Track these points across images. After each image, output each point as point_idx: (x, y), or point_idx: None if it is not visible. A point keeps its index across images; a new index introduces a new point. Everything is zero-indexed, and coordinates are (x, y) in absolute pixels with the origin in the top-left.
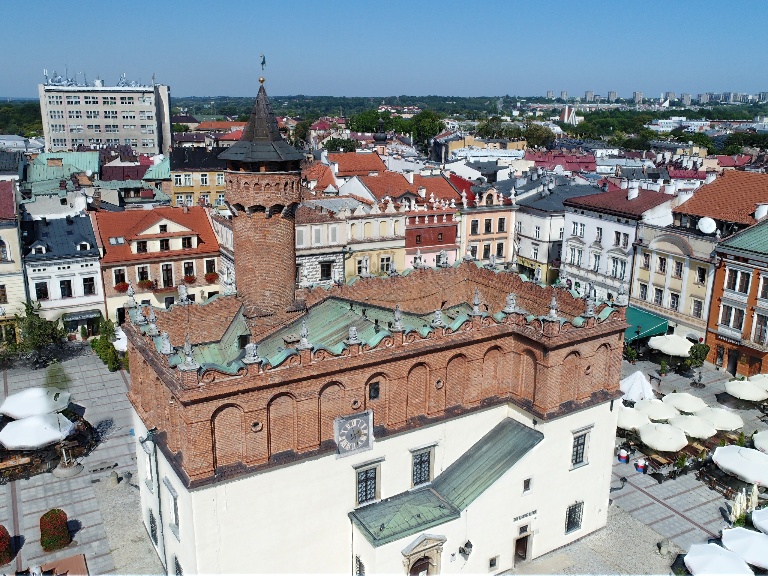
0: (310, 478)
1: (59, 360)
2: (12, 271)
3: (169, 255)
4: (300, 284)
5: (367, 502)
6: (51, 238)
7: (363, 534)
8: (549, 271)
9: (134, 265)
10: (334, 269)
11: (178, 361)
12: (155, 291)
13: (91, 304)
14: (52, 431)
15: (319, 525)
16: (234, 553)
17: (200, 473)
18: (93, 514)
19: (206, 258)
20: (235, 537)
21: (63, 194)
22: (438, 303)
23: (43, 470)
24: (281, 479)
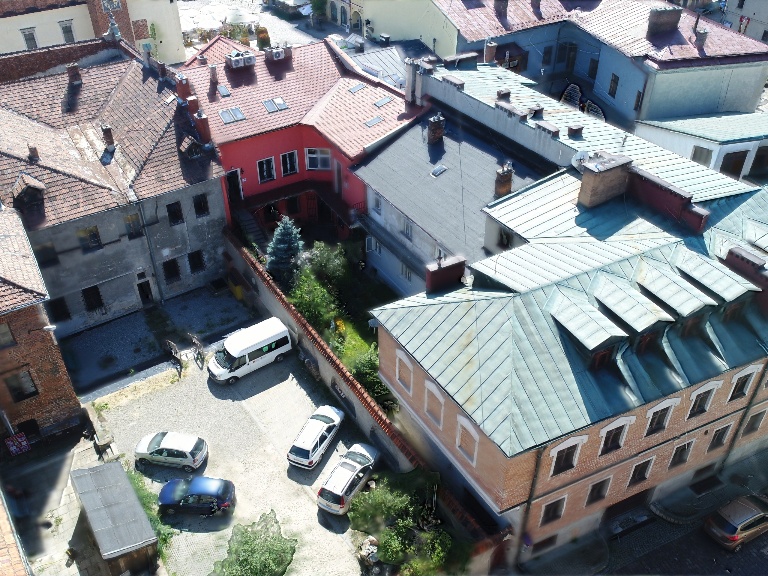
0: None
1: None
2: None
3: None
4: None
5: None
6: None
7: None
8: None
9: None
10: None
11: None
12: None
13: None
14: None
15: None
16: None
17: None
18: None
19: None
20: None
21: (460, 77)
22: None
23: None
24: None
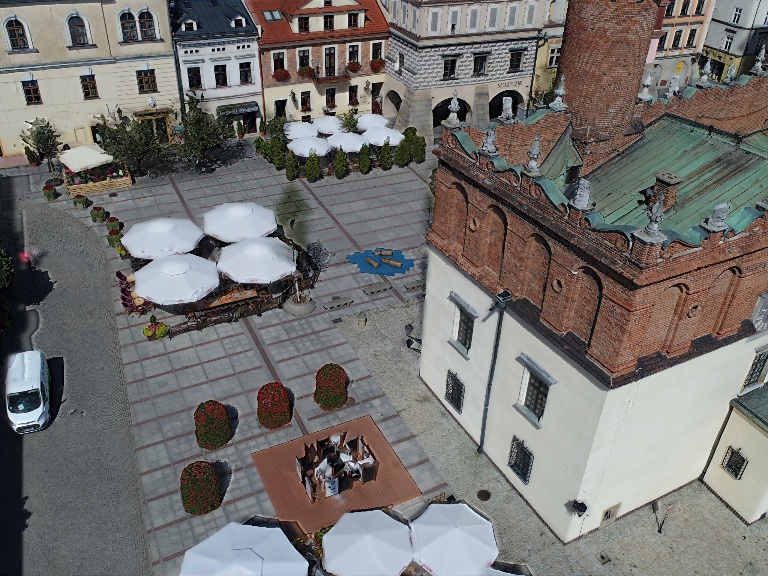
0: (715, 366)
1: (224, 163)
2: (162, 52)
3: (334, 36)
4: (639, 96)
5: (749, 387)
6: (196, 10)
7: (759, 429)
8: (742, 66)
9: (295, 48)
10: (676, 76)
11: (601, 221)
12: (318, 81)
13: (247, 95)
14: (281, 261)
15: (702, 415)
16: (621, 451)
17: (623, 369)
18: (355, 364)
19: (373, 40)
20: (628, 435)
21: None
22: (761, 121)
23: (274, 305)
24: (690, 369)
